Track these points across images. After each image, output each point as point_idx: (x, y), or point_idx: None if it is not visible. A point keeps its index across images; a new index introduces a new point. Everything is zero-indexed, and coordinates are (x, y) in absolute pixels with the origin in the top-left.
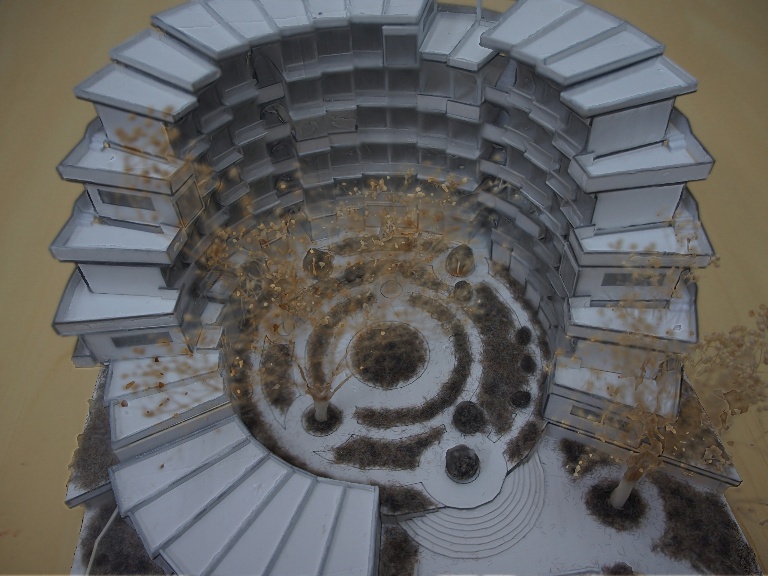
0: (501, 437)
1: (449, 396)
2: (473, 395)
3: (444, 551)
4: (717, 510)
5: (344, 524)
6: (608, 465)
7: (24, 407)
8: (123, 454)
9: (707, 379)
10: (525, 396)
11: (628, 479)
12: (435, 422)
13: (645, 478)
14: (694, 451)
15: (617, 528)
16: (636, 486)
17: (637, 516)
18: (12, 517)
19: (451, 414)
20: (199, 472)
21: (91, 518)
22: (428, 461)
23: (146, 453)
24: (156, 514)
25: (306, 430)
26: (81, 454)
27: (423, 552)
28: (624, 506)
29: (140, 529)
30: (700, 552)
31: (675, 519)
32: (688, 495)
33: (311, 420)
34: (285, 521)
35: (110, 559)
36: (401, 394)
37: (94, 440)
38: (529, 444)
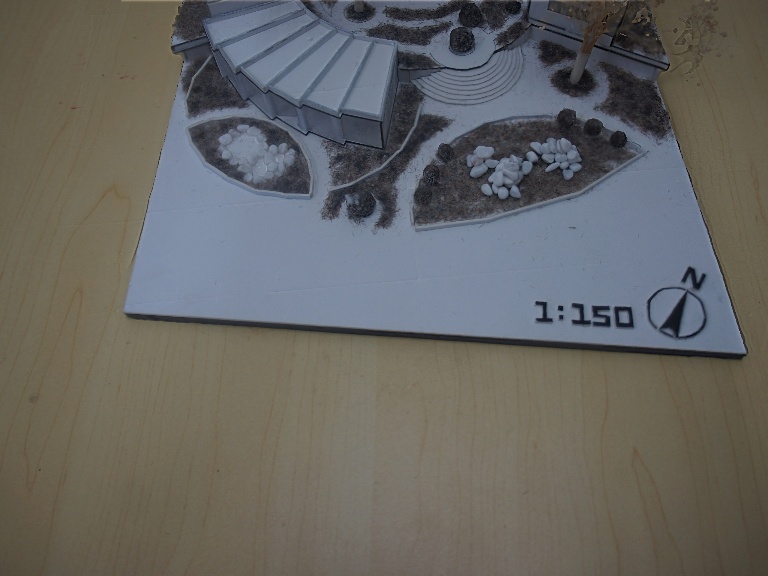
0: (494, 31)
1: (458, 3)
2: (477, 5)
3: (442, 98)
4: (648, 89)
5: (371, 62)
6: (573, 59)
7: (133, 2)
8: (214, 9)
9: (667, 16)
10: (516, 3)
11: (582, 51)
12: (445, 19)
13: (599, 68)
14: (638, 44)
15: (571, 95)
16: (591, 72)
17: (588, 89)
18: (130, 68)
19: (458, 15)
20: (268, 28)
21: (188, 66)
22: (437, 41)
23: (230, 13)
24: (237, 50)
25: (347, 18)
26: (181, 18)
27: (427, 99)
28: (579, 82)
29: (227, 55)
30: (629, 111)
31: (615, 92)
32: (629, 79)
33: (351, 11)
34: (329, 58)
35: (203, 89)
36: (421, 1)
37: (190, 11)
38: (514, 35)
